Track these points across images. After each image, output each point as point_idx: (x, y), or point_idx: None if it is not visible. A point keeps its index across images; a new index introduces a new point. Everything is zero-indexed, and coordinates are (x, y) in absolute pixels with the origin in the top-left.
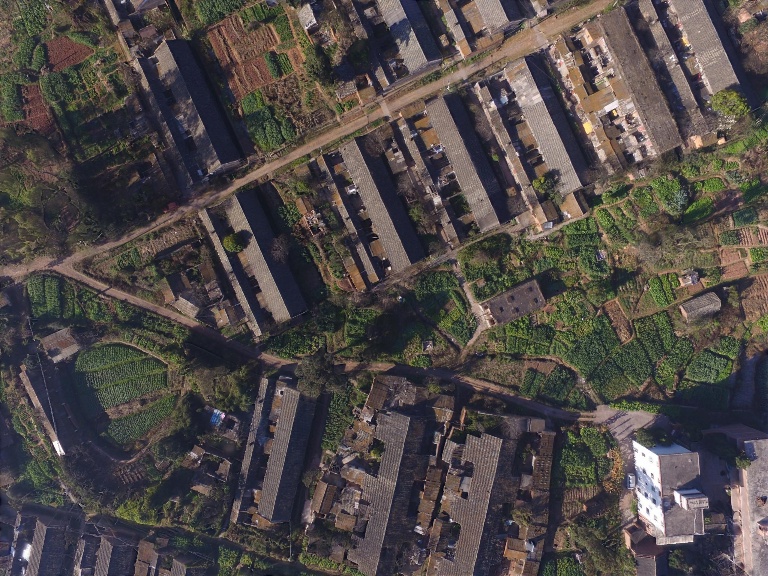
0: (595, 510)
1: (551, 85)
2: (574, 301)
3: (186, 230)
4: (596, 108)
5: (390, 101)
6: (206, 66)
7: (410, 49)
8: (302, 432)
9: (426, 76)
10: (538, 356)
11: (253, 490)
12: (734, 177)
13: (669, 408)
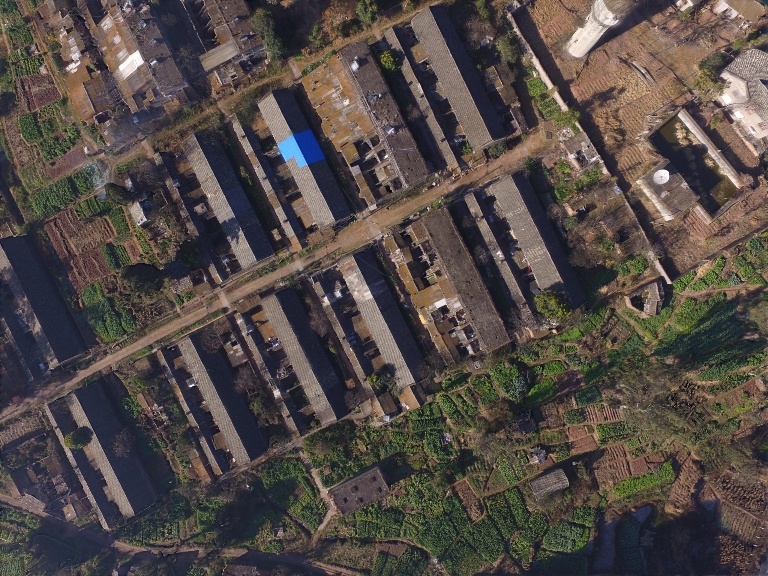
0: None
1: (384, 278)
2: (422, 484)
3: (33, 421)
4: (427, 304)
5: (228, 292)
6: (44, 259)
7: (240, 247)
8: None
9: (261, 269)
10: (389, 539)
11: None
12: (573, 360)
13: None
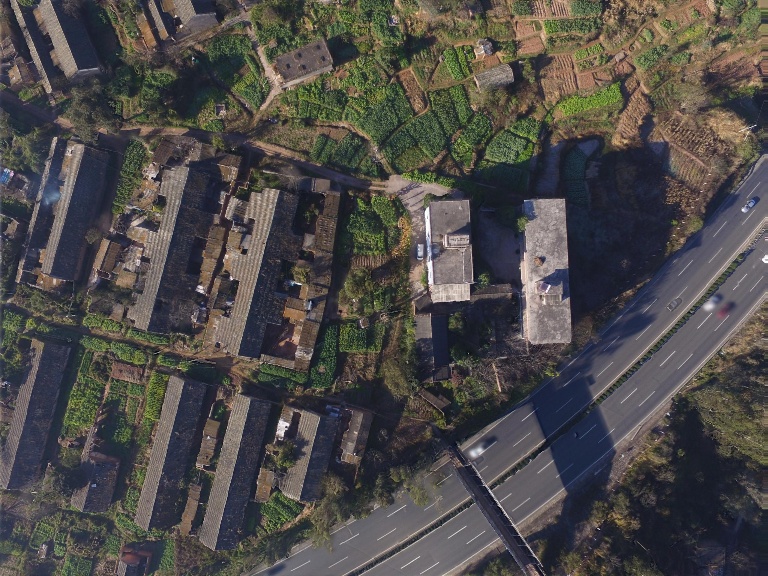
0: (380, 275)
1: None
2: (366, 66)
3: None
4: None
5: None
6: None
7: None
8: (88, 189)
9: None
10: (330, 122)
11: (39, 251)
12: None
13: (464, 183)
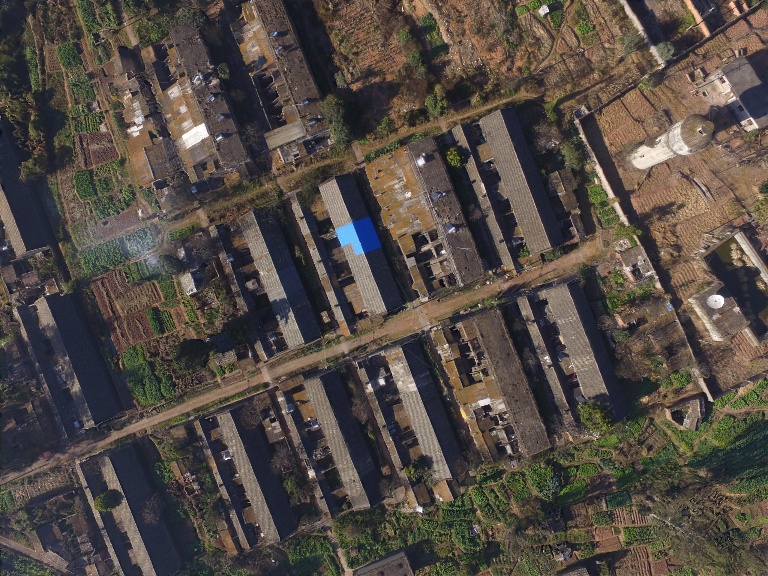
0: None
1: (429, 370)
2: (446, 573)
3: (62, 477)
4: (470, 400)
5: (271, 368)
6: (88, 317)
7: (289, 327)
8: None
9: (307, 349)
10: None
11: None
12: (608, 464)
13: None
